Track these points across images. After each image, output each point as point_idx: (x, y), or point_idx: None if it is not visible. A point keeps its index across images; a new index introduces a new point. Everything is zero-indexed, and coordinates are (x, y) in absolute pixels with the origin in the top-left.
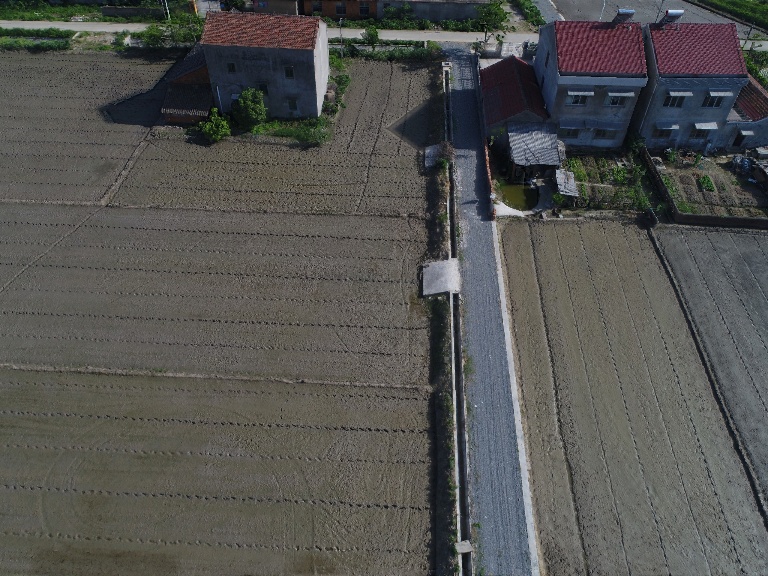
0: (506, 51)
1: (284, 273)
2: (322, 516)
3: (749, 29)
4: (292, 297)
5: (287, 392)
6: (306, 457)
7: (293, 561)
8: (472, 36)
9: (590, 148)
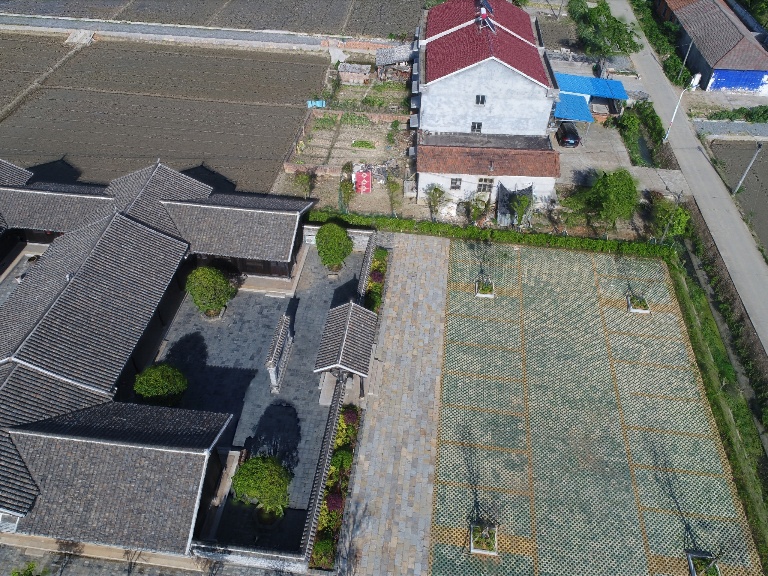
0: None
1: (300, 3)
2: (159, 8)
3: None
4: (281, 4)
5: (221, 3)
6: (186, 6)
7: (146, 4)
8: (654, 74)
9: (416, 94)
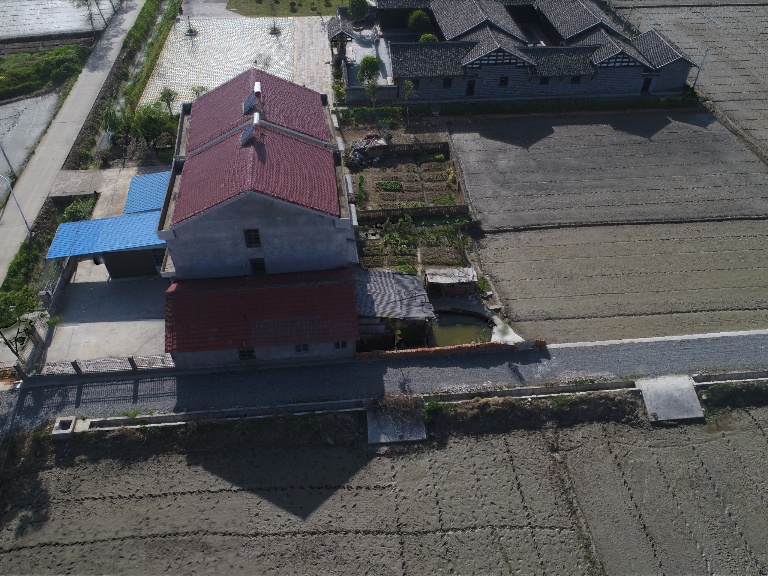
0: (42, 330)
1: None
2: None
3: (18, 104)
4: None
5: None
6: None
7: None
8: None
9: None
